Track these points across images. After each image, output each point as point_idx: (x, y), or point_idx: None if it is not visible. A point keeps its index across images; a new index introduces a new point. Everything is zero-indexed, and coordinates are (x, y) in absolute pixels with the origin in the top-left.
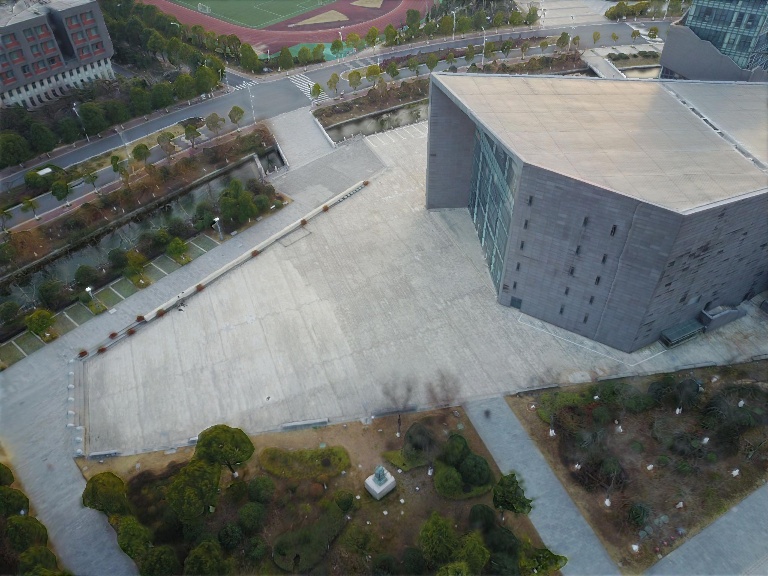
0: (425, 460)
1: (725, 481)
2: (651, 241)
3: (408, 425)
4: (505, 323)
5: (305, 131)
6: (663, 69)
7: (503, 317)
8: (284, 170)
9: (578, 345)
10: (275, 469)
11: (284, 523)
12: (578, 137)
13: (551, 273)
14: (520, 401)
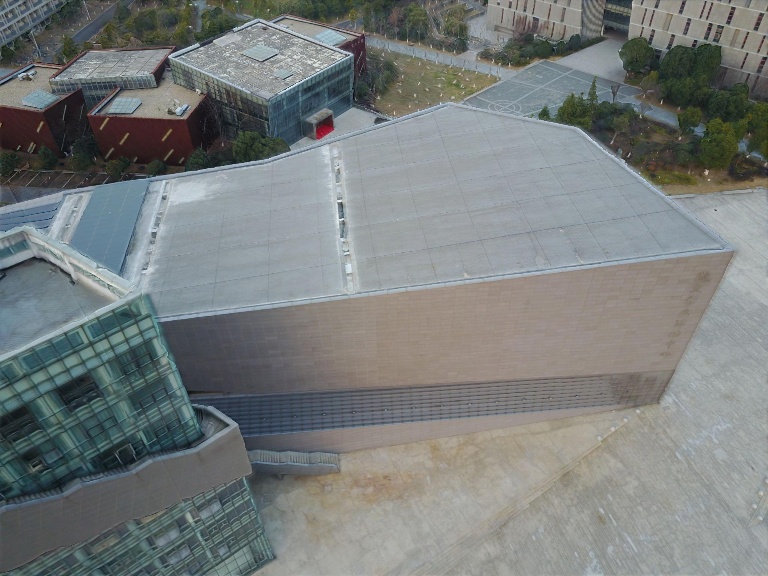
0: None
1: None
2: None
3: None
4: None
5: None
6: None
7: None
8: None
9: None
10: (683, 174)
11: (663, 155)
12: (517, 164)
13: None
14: None
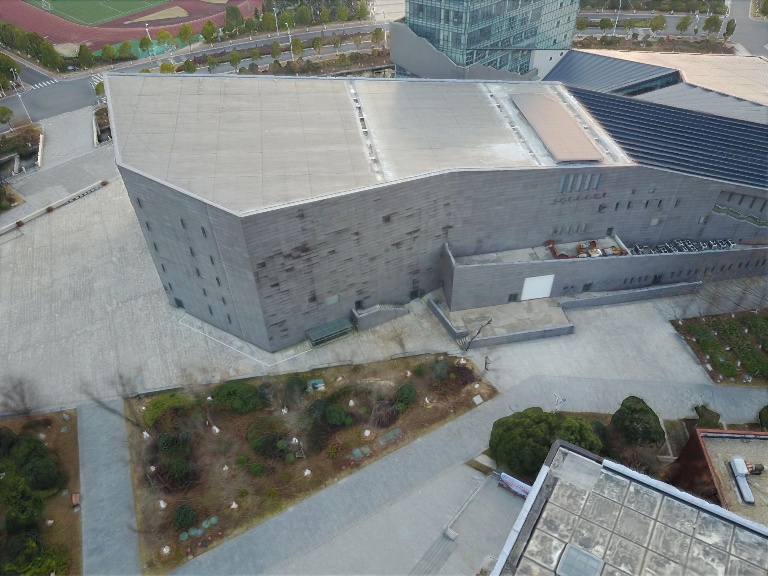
0: (3, 464)
1: (294, 481)
2: (232, 243)
3: (12, 429)
4: (165, 324)
5: (78, 130)
6: (396, 66)
7: (166, 318)
8: (33, 171)
9: (226, 345)
10: None
11: None
12: (202, 138)
13: (186, 274)
14: (136, 403)
